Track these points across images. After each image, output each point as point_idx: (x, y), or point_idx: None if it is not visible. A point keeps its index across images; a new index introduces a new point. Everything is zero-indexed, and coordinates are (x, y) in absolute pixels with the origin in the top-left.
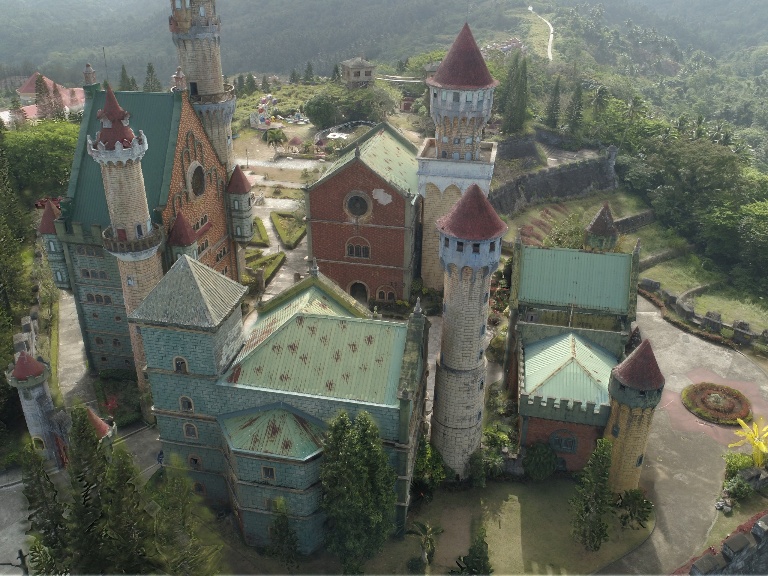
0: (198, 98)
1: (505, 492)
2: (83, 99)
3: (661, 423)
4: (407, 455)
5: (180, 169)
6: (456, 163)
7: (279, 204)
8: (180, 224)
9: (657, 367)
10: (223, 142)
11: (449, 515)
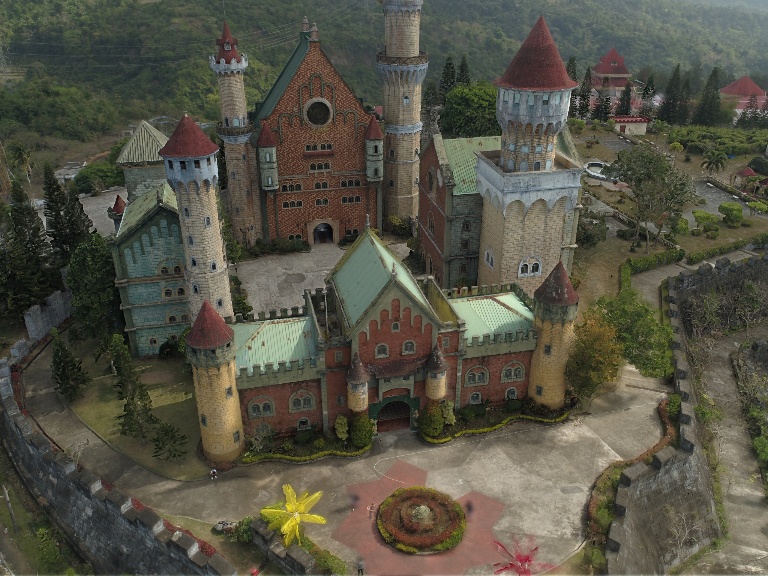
0: (380, 58)
1: (194, 390)
2: (619, 87)
3: (353, 476)
4: (122, 290)
5: (297, 98)
6: (488, 165)
7: (598, 209)
8: (262, 131)
9: (203, 330)
10: (398, 99)
11: (164, 373)
